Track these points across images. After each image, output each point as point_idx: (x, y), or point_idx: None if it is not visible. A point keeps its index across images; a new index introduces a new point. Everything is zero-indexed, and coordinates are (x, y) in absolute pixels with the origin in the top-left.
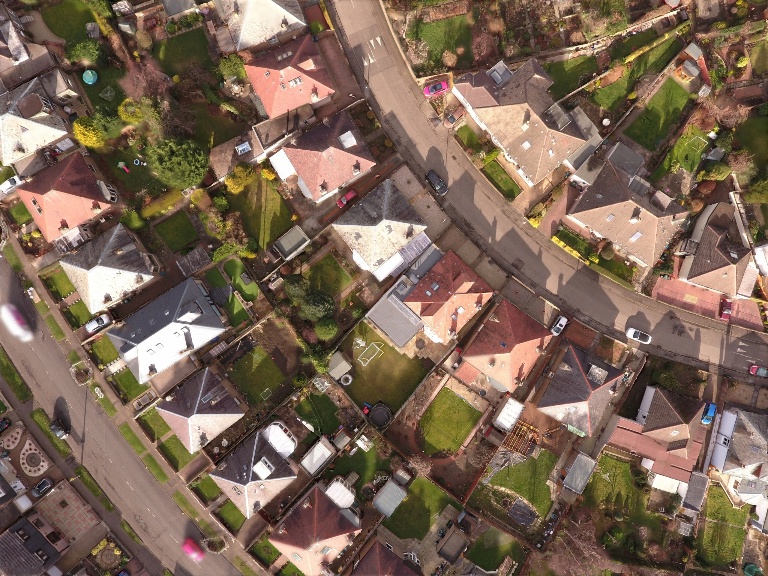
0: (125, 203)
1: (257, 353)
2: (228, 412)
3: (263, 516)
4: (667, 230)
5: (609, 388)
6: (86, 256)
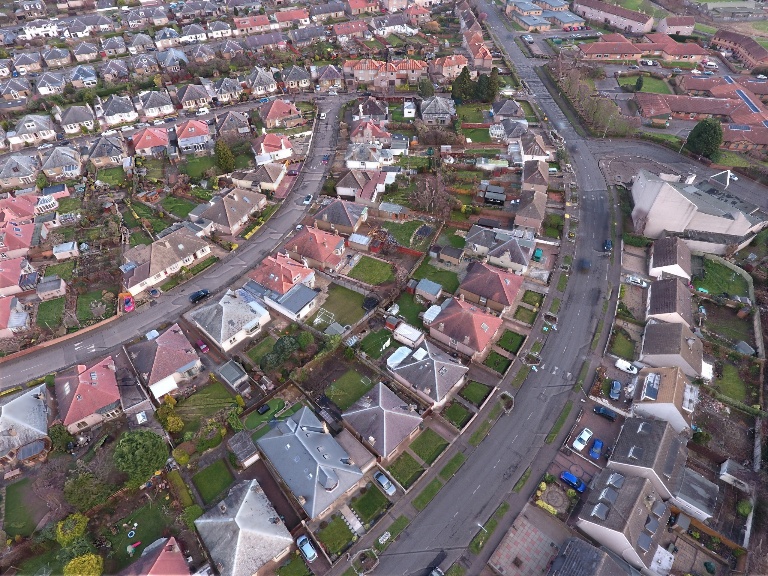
0: (174, 537)
1: (331, 392)
2: (378, 390)
3: (467, 364)
4: None
5: None
6: (225, 546)
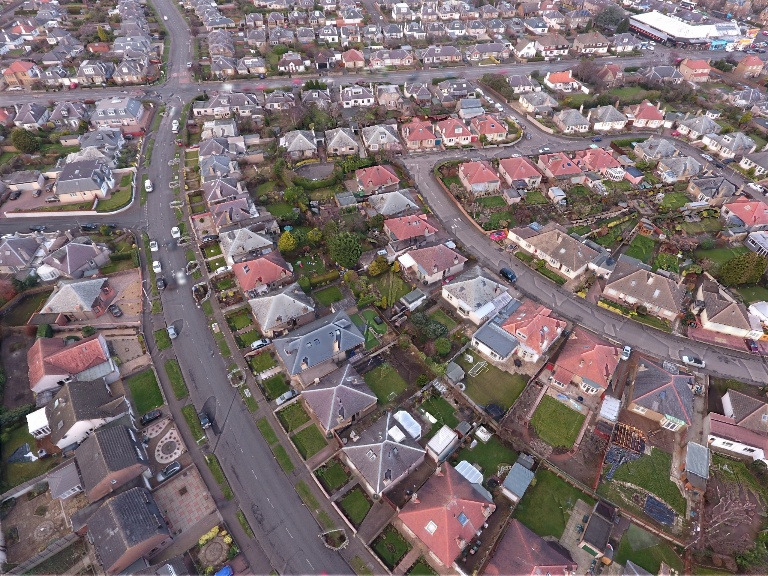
0: None
1: None
2: (365, 392)
3: (390, 500)
4: (676, 291)
5: (686, 382)
6: None
